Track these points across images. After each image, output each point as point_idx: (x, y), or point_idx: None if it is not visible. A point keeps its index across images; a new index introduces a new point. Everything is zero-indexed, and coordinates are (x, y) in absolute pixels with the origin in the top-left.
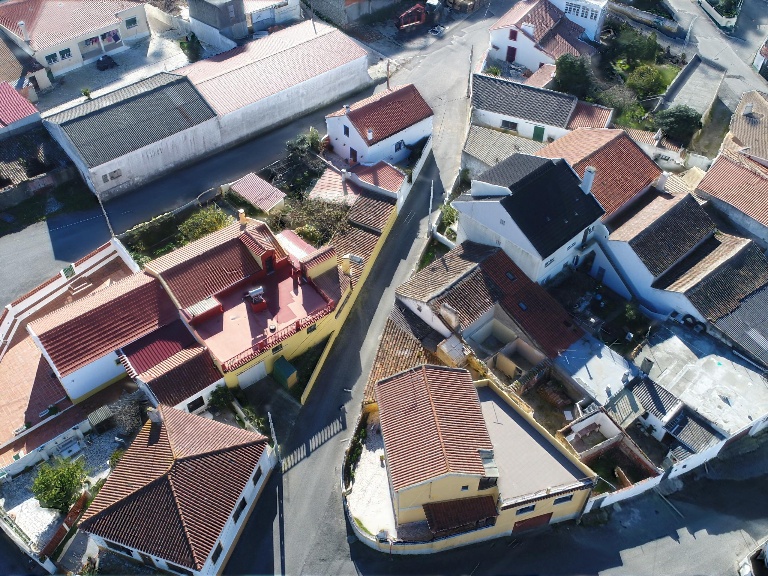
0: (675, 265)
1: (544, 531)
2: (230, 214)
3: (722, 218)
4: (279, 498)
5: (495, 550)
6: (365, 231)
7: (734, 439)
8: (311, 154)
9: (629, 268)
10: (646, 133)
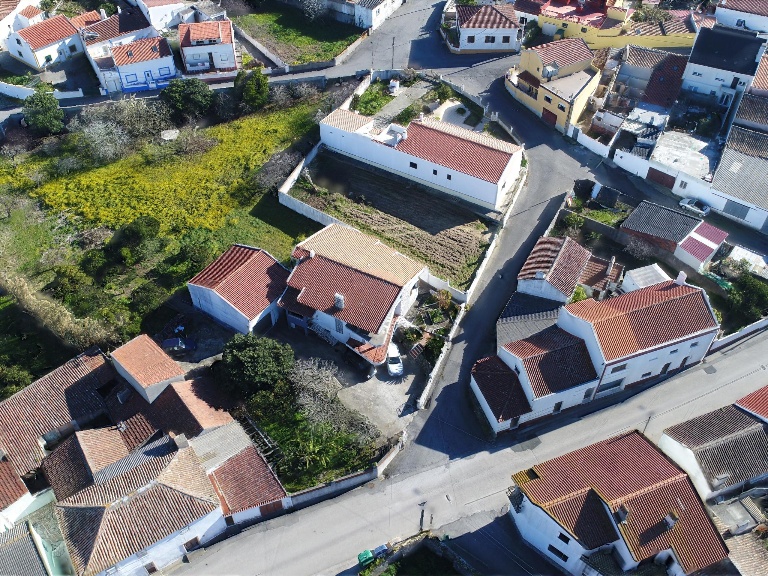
0: (761, 129)
1: (551, 127)
2: (633, 1)
3: None
4: (506, 56)
5: (531, 115)
6: (661, 30)
7: (660, 180)
8: (699, 3)
9: None
10: None
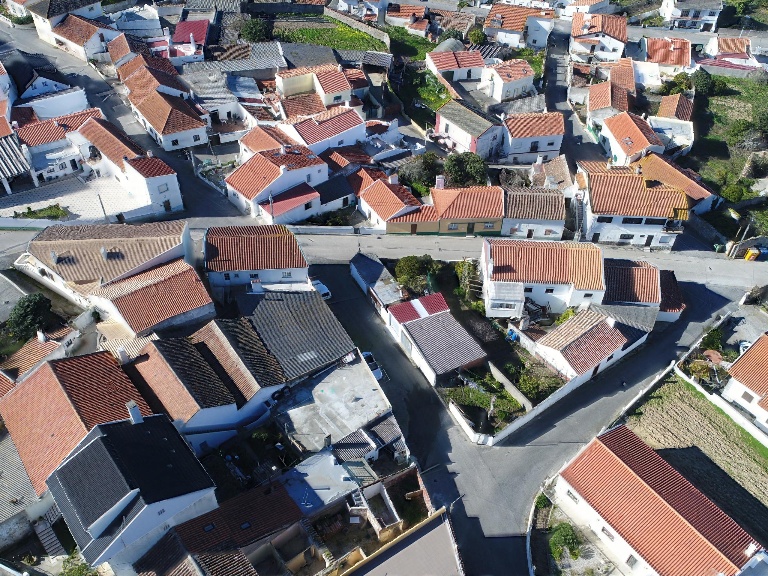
0: None
1: None
2: None
3: (173, 330)
4: None
5: None
6: None
7: None
8: None
9: (215, 420)
10: (29, 346)
